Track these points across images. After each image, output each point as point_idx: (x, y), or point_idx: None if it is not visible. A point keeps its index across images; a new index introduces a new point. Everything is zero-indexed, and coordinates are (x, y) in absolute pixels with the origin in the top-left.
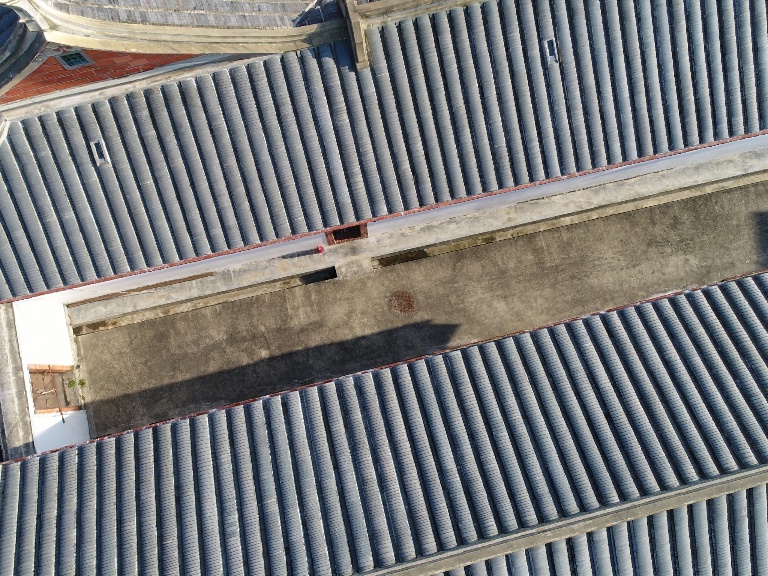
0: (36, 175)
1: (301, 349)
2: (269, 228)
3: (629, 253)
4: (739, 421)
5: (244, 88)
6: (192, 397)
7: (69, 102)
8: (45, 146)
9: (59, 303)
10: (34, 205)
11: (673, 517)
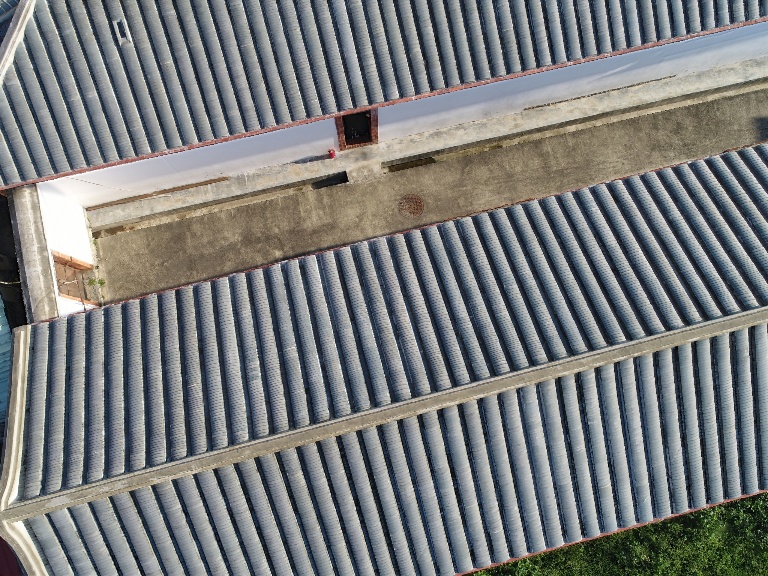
0: (61, 53)
1: (314, 250)
2: (285, 110)
3: (633, 157)
4: (741, 271)
5: None
6: None
7: None
8: (70, 24)
9: (79, 204)
10: (59, 84)
11: (678, 356)
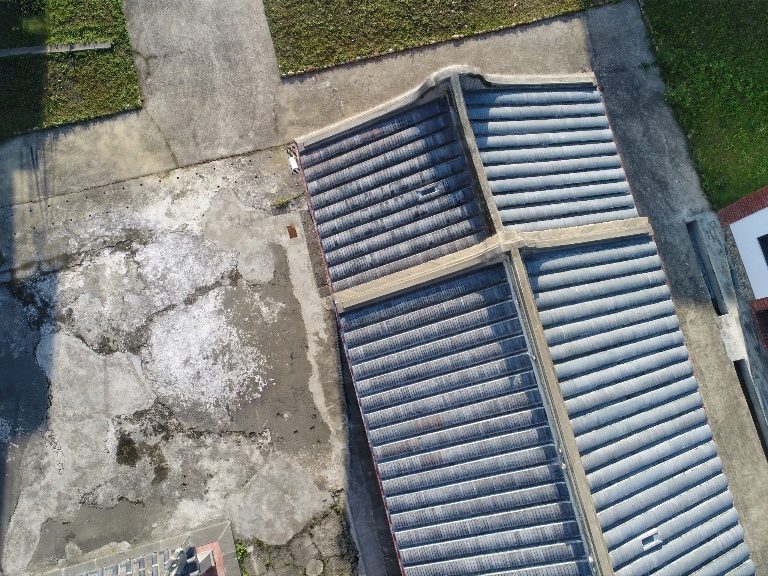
0: None
1: None
2: None
3: None
4: None
5: None
6: None
7: None
8: None
9: None
10: None
11: None
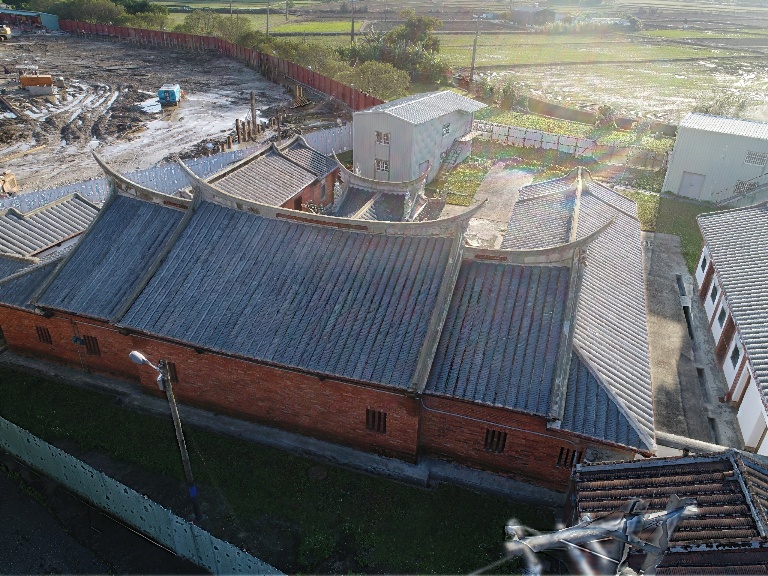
0: None
1: (682, 404)
2: None
3: None
4: None
5: (583, 287)
6: None
7: None
8: None
9: None
10: None
11: None
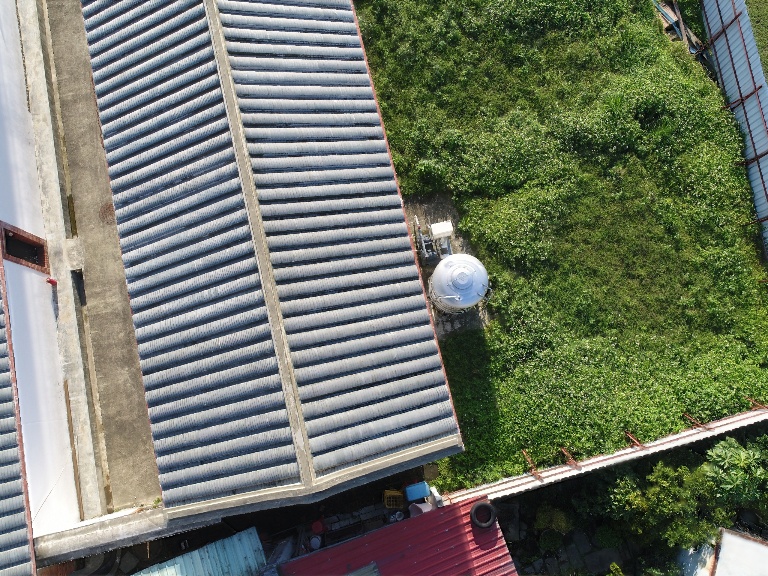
0: None
1: None
2: None
3: None
4: None
5: None
6: None
7: None
8: None
9: None
10: None
11: None
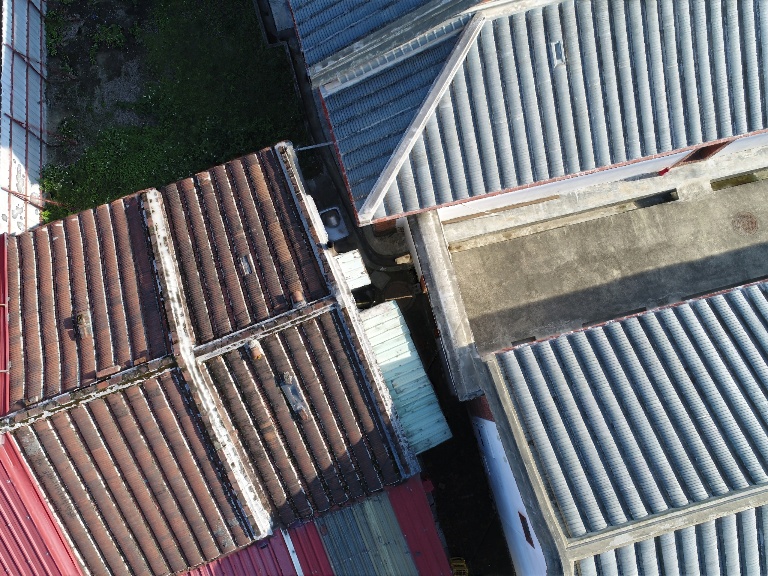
0: (497, 76)
1: (652, 268)
2: (699, 131)
3: None
4: None
5: None
6: (550, 316)
7: (544, 0)
8: (510, 46)
9: None
10: (488, 107)
11: None
